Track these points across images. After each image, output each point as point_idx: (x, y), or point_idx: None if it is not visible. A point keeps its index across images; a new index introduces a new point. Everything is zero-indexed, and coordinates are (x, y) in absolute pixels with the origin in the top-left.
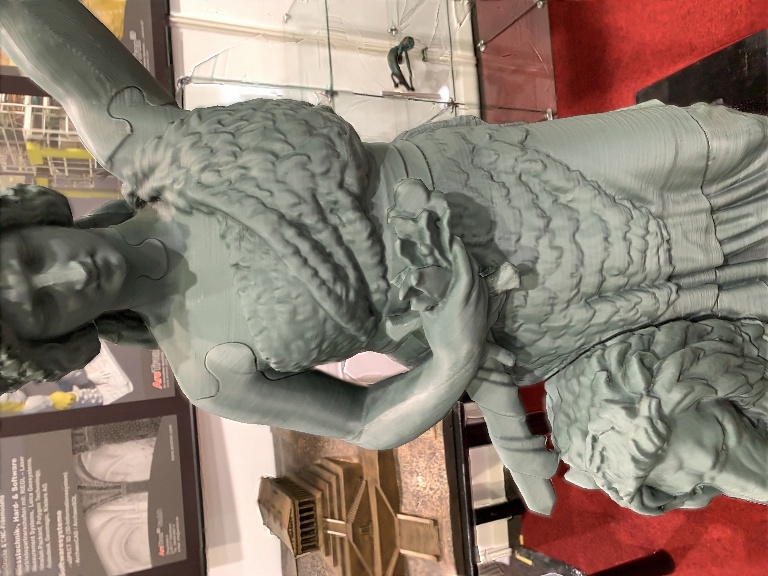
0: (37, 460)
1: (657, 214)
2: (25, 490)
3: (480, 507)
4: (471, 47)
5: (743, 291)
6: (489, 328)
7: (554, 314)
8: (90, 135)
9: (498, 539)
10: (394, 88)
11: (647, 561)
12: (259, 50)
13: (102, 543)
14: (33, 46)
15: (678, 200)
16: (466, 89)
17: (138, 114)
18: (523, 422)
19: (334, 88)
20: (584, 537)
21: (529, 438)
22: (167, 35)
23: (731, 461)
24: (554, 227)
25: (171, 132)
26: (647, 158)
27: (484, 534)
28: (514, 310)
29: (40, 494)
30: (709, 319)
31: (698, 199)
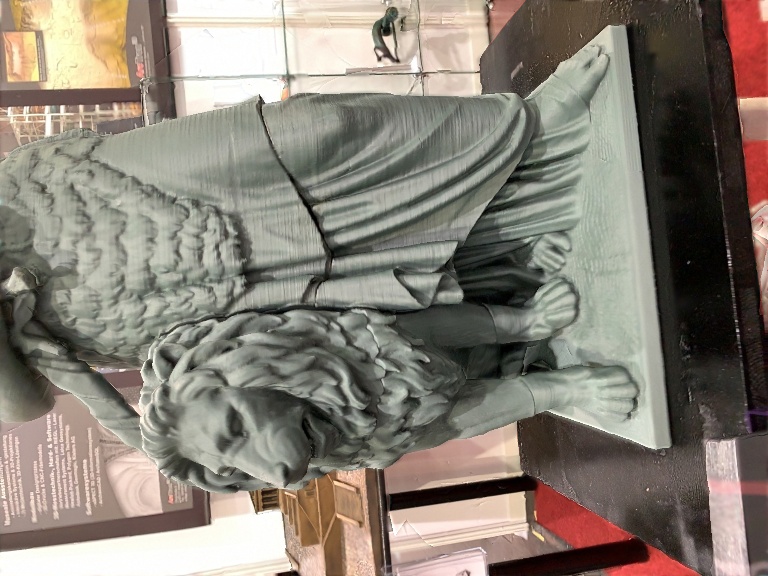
0: (66, 417)
1: (229, 211)
2: (57, 441)
3: (488, 480)
4: (484, 5)
5: (356, 280)
6: (24, 323)
7: (103, 309)
8: None
9: (514, 513)
10: (377, 62)
11: (619, 547)
12: (206, 46)
13: (120, 489)
14: None
15: (259, 195)
16: (475, 51)
17: None
18: (113, 404)
19: (290, 72)
20: (580, 517)
21: (126, 418)
22: (164, 36)
23: (245, 447)
24: (96, 231)
25: None
26: (198, 159)
27: (498, 507)
28: (61, 307)
29: (69, 445)
30: (293, 310)
31: (284, 192)
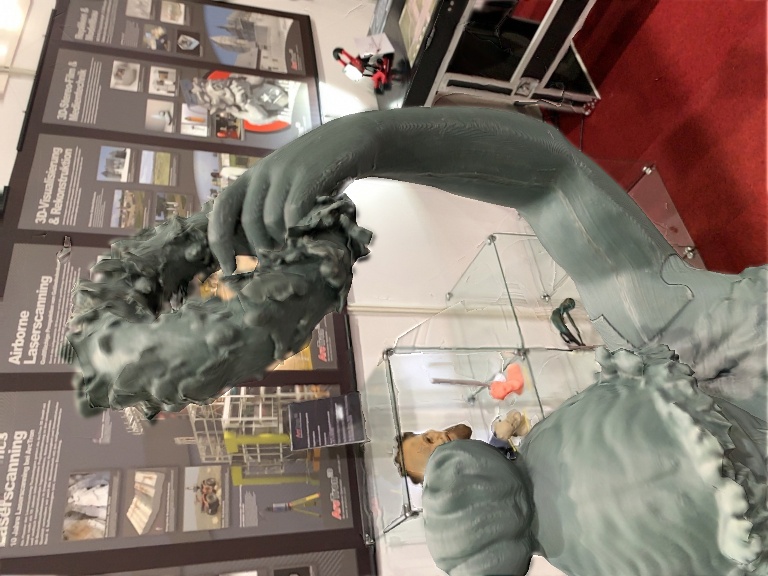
0: None
1: None
2: None
3: None
4: None
5: None
6: None
7: None
8: (639, 308)
9: None
10: None
11: None
12: (457, 317)
13: None
14: (597, 217)
15: None
16: None
17: (692, 279)
18: None
19: (525, 346)
20: None
21: None
22: (346, 322)
23: None
24: None
25: (746, 290)
26: None
27: None
28: None
29: None
30: None
31: None
